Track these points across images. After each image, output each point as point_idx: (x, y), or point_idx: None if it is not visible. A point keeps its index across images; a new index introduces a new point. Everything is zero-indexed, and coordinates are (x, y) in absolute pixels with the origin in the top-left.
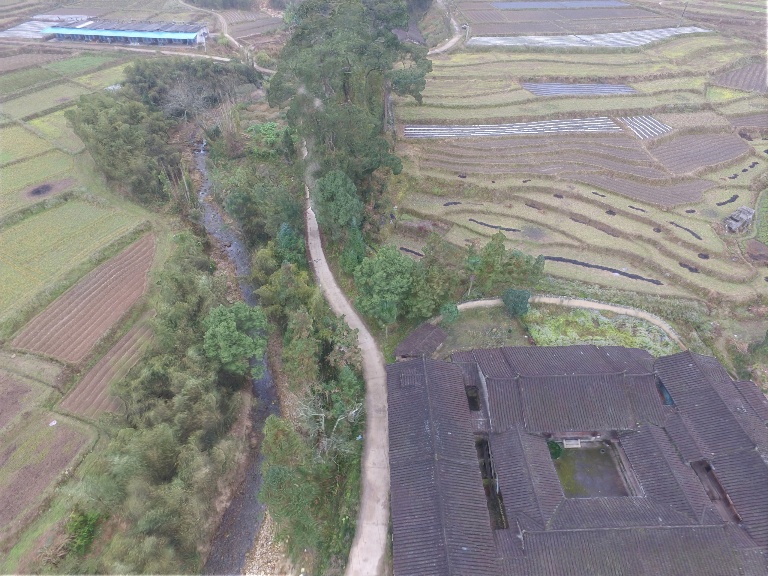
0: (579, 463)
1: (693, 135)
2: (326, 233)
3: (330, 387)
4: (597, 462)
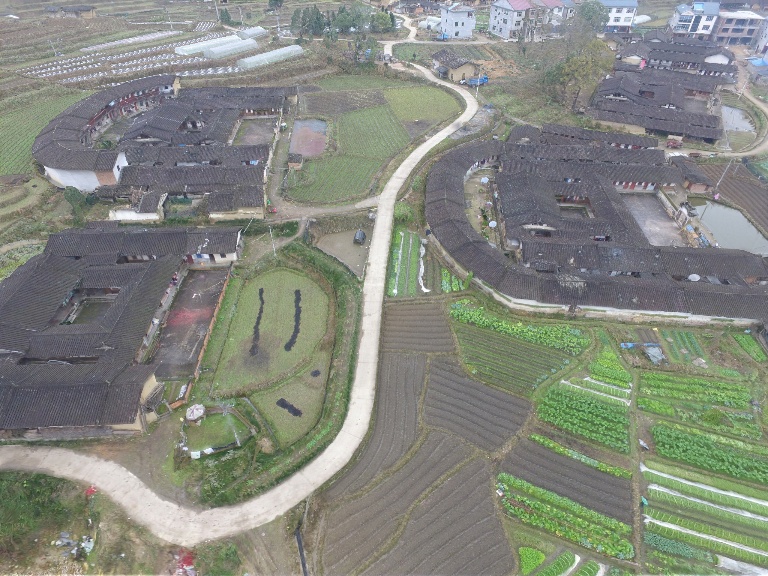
0: (86, 319)
1: None
2: None
3: None
4: (92, 310)
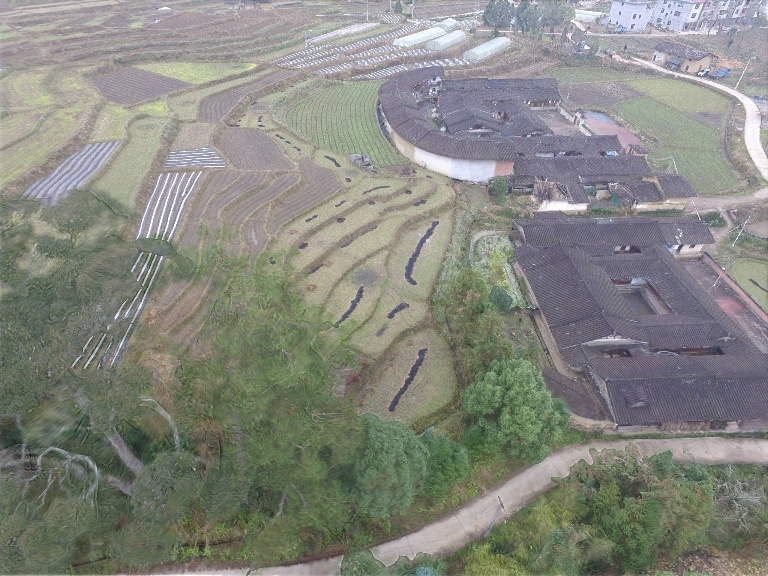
0: None
1: (220, 144)
2: (335, 538)
3: (682, 482)
4: None
